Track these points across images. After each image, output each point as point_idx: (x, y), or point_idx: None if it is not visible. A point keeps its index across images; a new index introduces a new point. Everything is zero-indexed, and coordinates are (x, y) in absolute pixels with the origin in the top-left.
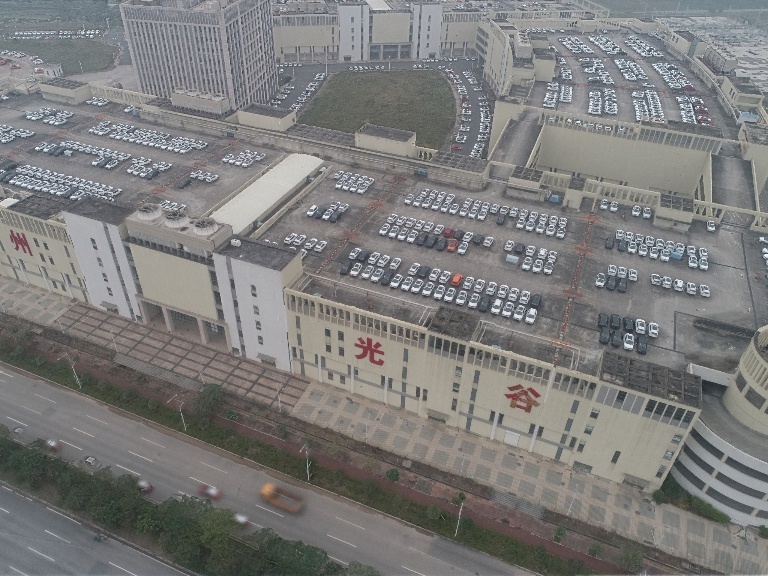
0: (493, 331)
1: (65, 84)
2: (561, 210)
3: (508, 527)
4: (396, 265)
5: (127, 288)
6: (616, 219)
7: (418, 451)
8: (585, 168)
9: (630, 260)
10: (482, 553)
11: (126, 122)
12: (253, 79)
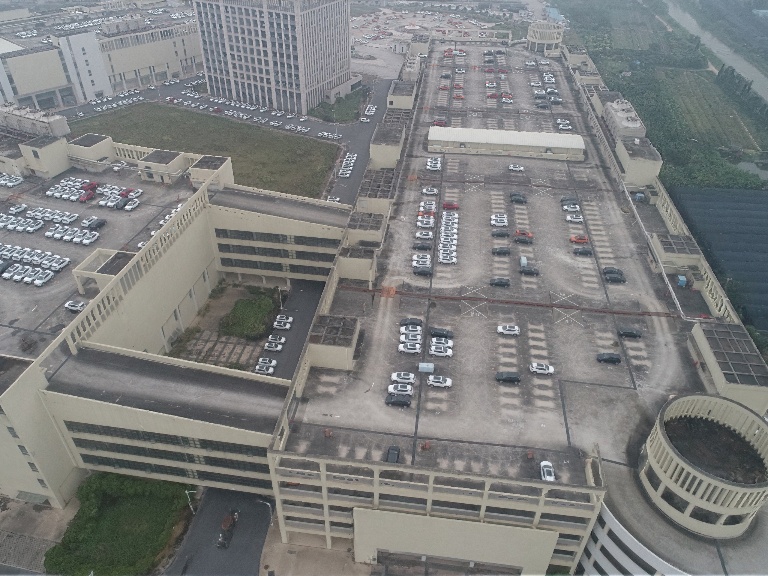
0: None
1: None
2: None
3: None
4: None
5: None
6: None
7: None
8: None
9: None
10: None
11: None
12: (244, 70)
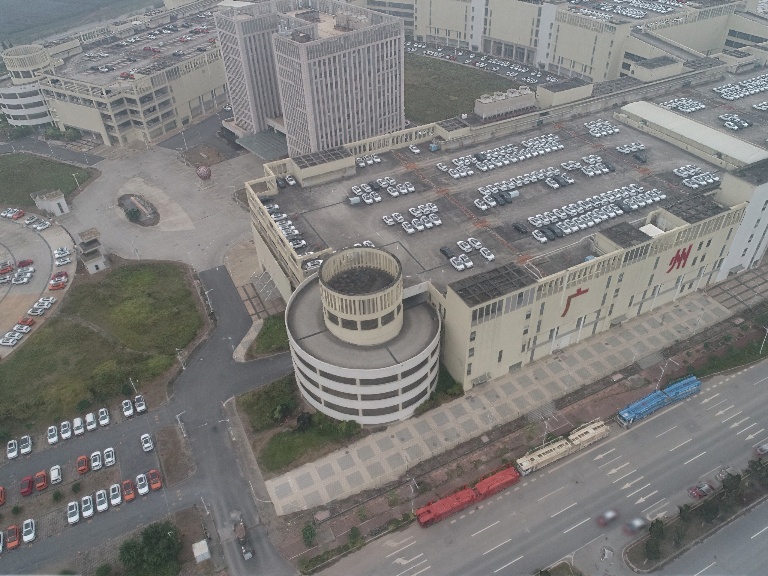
0: None
1: (325, 157)
2: None
3: None
4: None
5: (765, 236)
6: None
7: None
8: None
9: None
10: None
11: (445, 158)
12: None
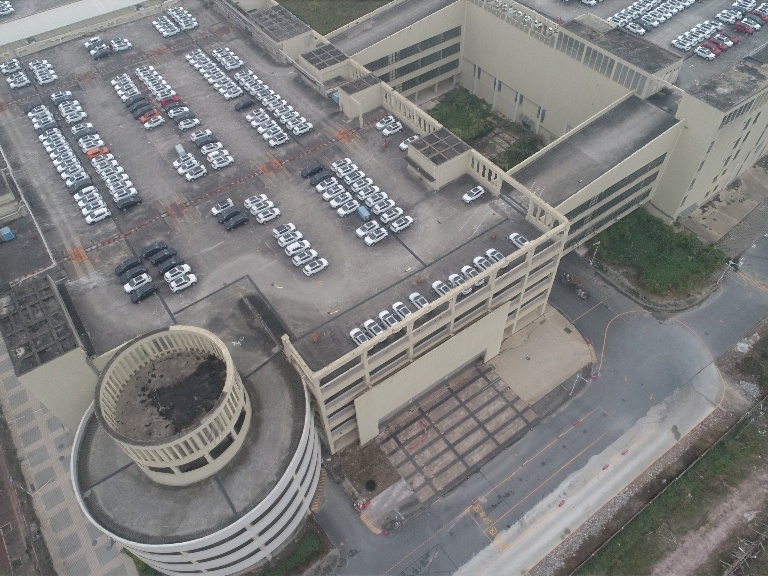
0: (49, 216)
1: None
2: (330, 114)
3: None
4: (70, 119)
5: None
6: (375, 145)
7: None
8: (506, 75)
9: (304, 198)
10: None
11: None
12: None
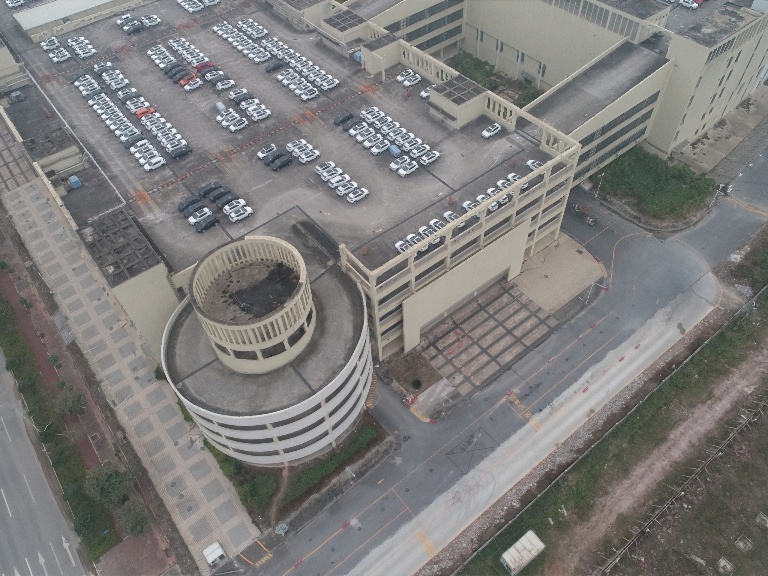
0: (109, 167)
1: None
2: (353, 71)
3: (39, 341)
4: (115, 85)
5: None
6: (397, 95)
7: (45, 257)
8: (507, 36)
9: (339, 142)
10: (1, 349)
11: None
12: None
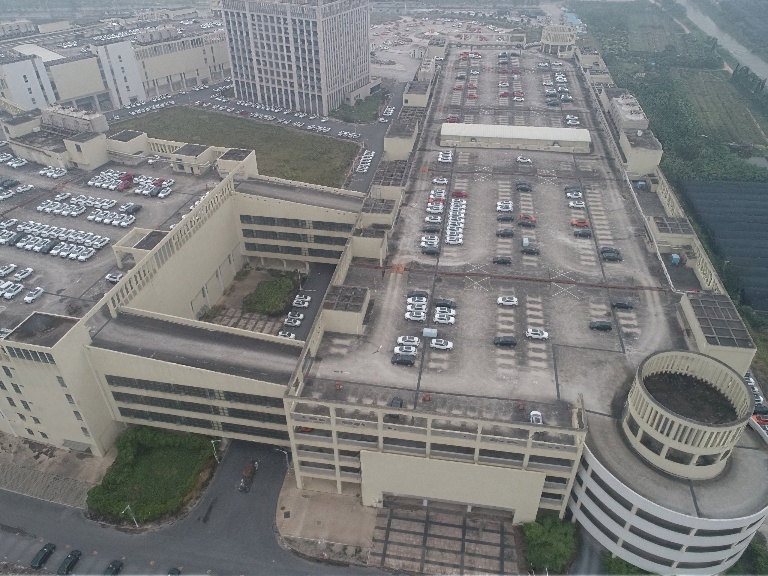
0: None
1: None
2: None
3: None
4: None
5: None
6: None
7: None
8: None
9: None
10: None
11: None
12: (269, 75)
